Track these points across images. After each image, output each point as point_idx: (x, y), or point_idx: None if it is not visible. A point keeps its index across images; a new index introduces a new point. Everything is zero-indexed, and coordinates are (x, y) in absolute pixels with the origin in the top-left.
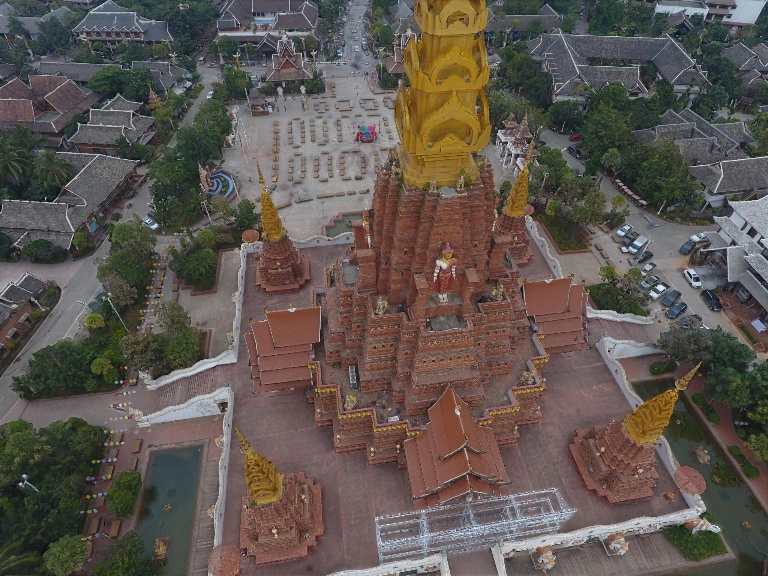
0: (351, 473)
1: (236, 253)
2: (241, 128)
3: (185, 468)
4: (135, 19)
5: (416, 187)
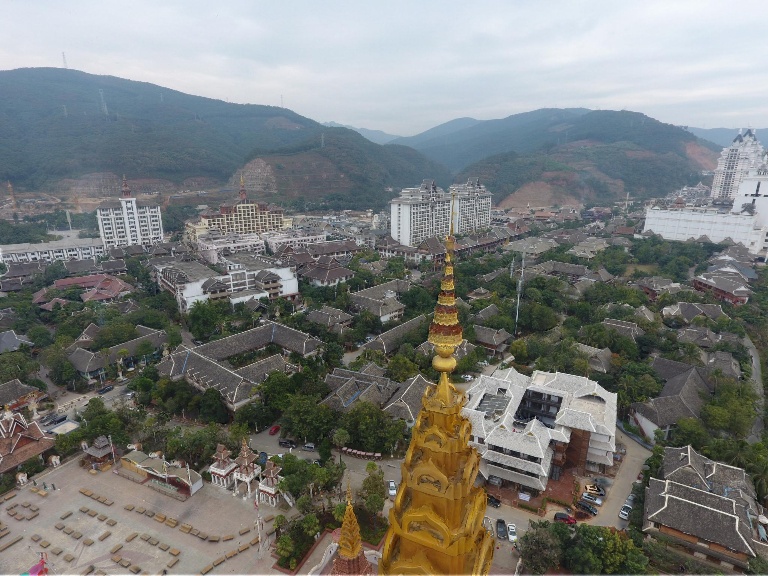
0: None
1: None
2: None
3: None
4: None
5: None
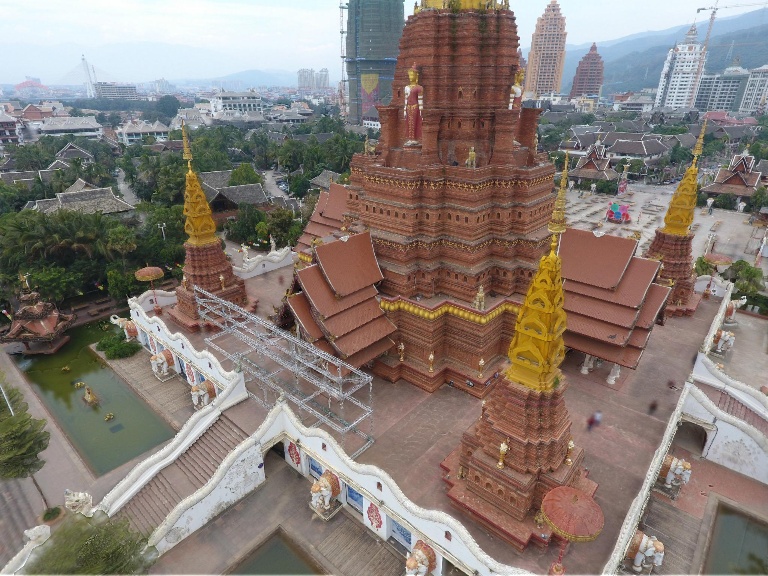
0: None
1: None
2: None
3: None
4: None
5: (415, 14)
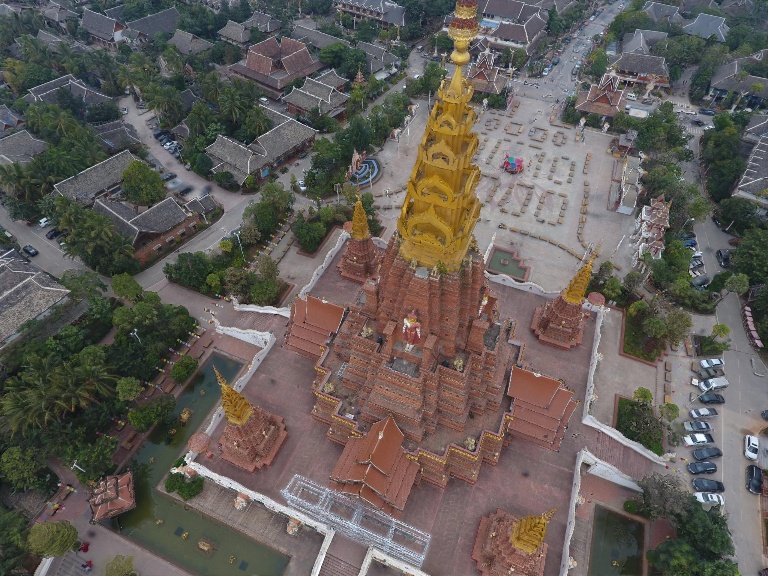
0: (313, 437)
1: None
2: (413, 124)
3: (226, 373)
4: (382, 1)
5: (404, 259)
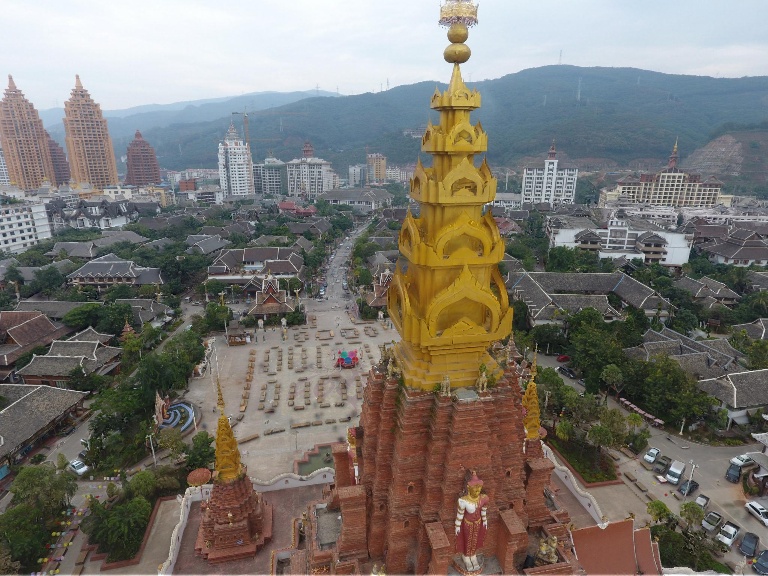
0: None
1: (178, 502)
2: (214, 358)
3: None
4: (131, 267)
5: (422, 390)
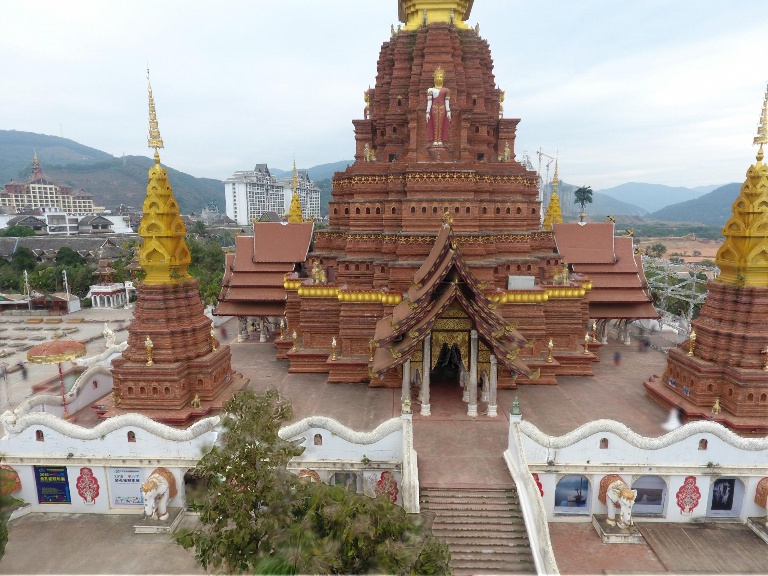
0: (618, 371)
1: None
2: None
3: None
4: None
5: None
